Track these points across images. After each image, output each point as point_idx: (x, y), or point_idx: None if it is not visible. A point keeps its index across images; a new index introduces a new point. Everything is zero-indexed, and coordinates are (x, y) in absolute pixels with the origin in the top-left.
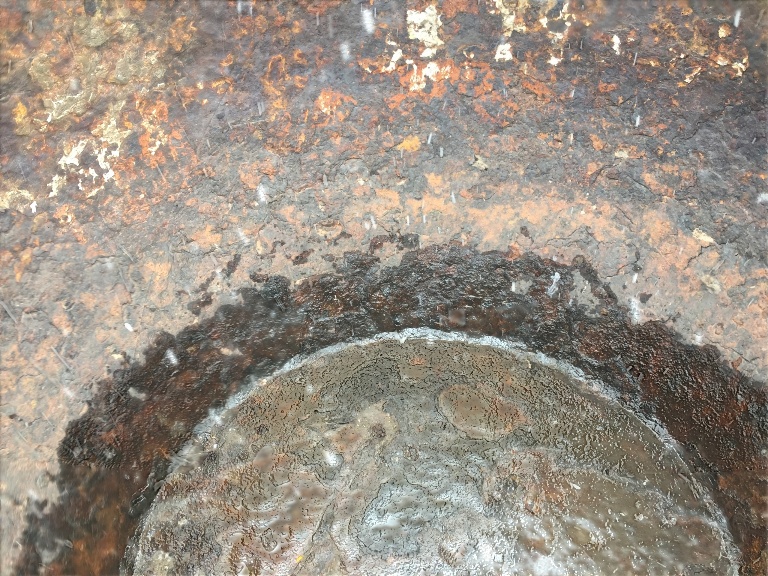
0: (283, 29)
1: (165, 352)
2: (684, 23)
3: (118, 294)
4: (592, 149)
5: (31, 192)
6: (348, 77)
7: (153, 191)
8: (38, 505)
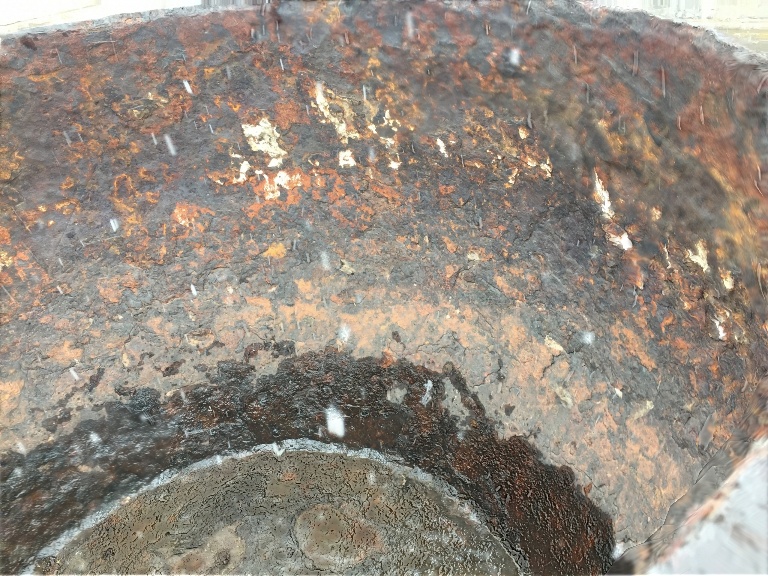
0: (121, 150)
1: (12, 472)
2: (491, 125)
3: None
4: (447, 251)
5: None
6: (201, 190)
7: None
8: None
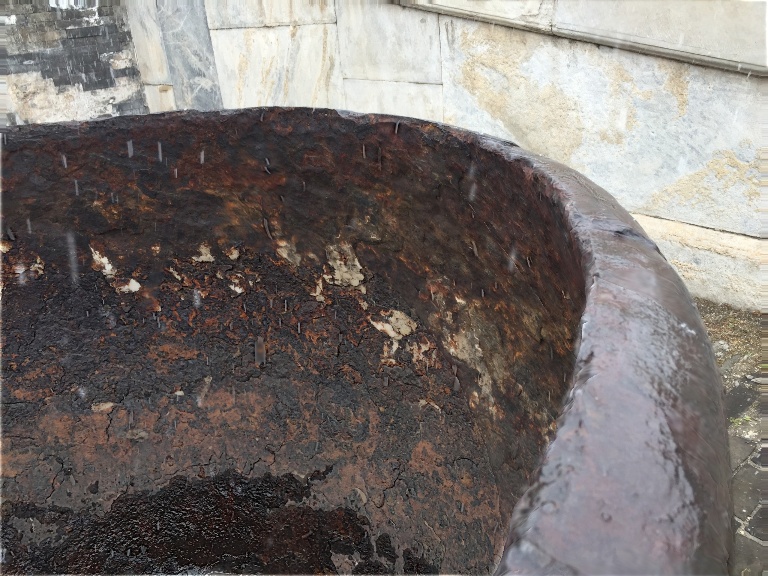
0: None
1: None
2: None
3: None
4: None
5: None
6: None
7: None
8: None
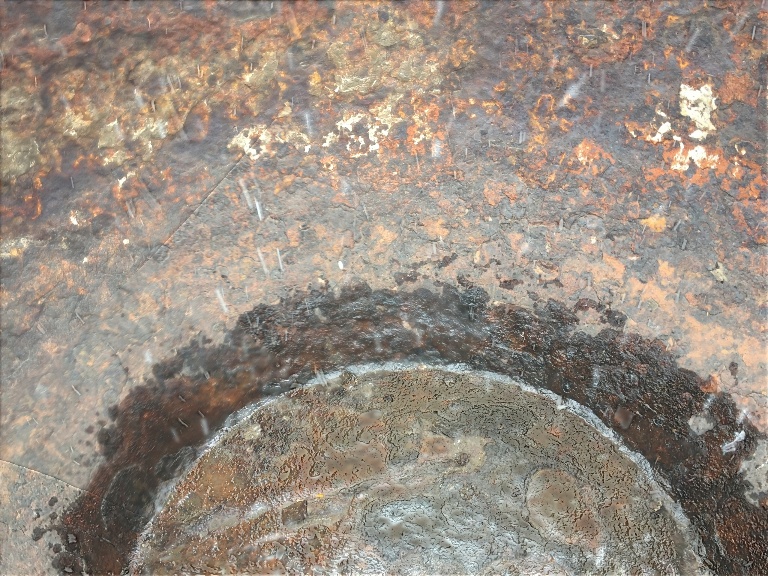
0: (557, 72)
1: (359, 298)
2: None
3: (345, 237)
4: None
5: (309, 137)
6: (613, 135)
7: (406, 173)
8: (205, 339)
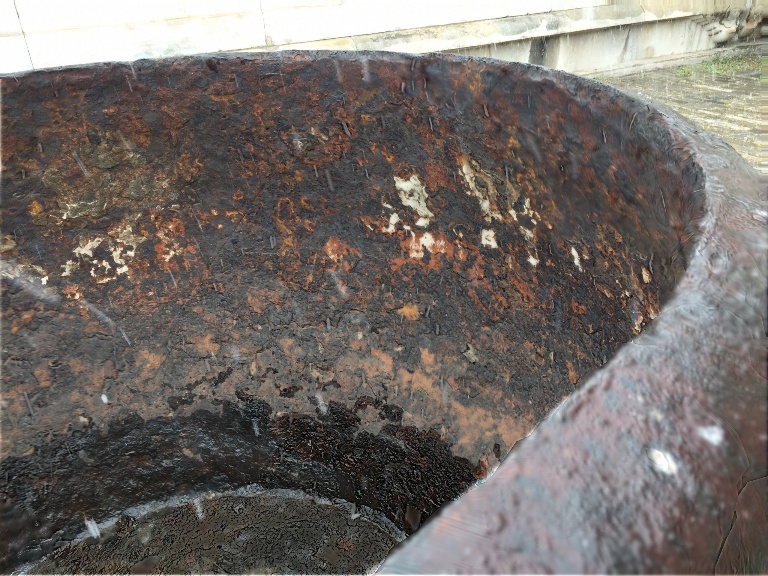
0: (286, 176)
1: (130, 431)
2: (621, 252)
3: (106, 368)
4: (568, 379)
5: (45, 269)
6: (354, 230)
7: (163, 291)
8: None
